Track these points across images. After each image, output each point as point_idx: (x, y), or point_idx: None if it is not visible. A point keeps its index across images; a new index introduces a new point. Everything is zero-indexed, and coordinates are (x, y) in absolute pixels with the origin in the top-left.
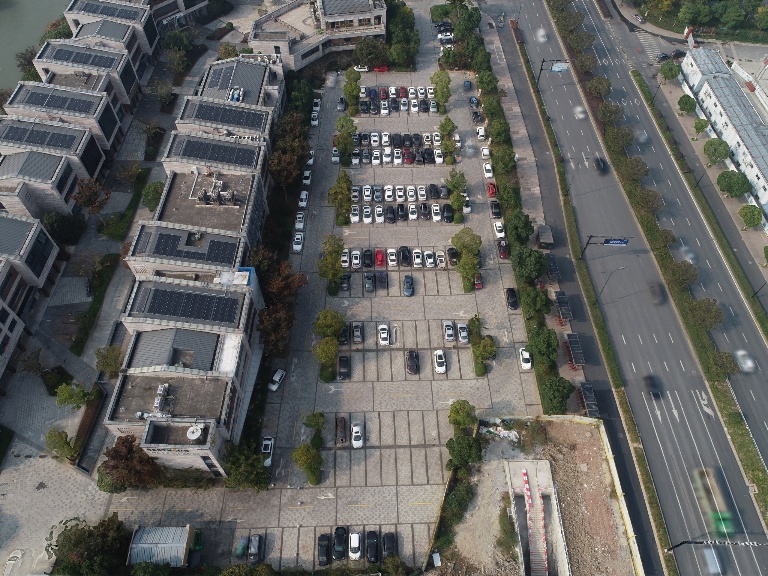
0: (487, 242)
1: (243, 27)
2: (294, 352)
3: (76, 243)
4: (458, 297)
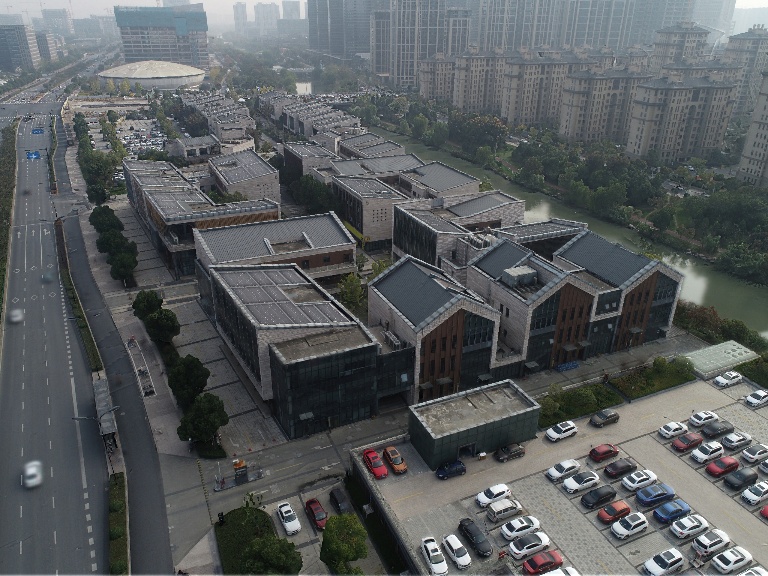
0: None
1: None
2: None
3: None
4: None
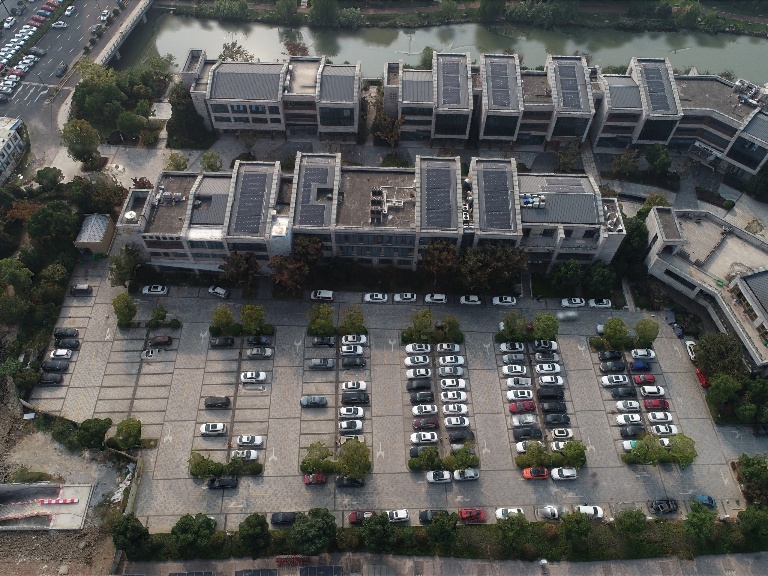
0: (379, 499)
1: (737, 219)
2: (247, 304)
3: (375, 145)
4: (296, 455)
